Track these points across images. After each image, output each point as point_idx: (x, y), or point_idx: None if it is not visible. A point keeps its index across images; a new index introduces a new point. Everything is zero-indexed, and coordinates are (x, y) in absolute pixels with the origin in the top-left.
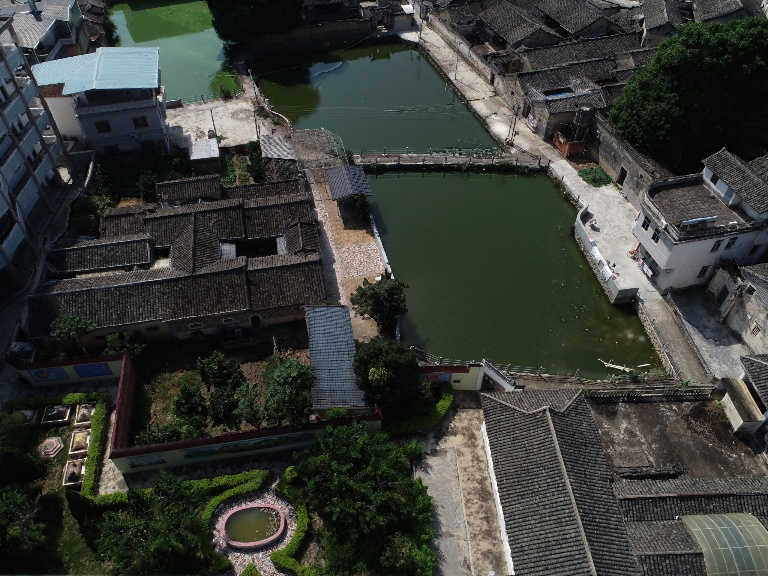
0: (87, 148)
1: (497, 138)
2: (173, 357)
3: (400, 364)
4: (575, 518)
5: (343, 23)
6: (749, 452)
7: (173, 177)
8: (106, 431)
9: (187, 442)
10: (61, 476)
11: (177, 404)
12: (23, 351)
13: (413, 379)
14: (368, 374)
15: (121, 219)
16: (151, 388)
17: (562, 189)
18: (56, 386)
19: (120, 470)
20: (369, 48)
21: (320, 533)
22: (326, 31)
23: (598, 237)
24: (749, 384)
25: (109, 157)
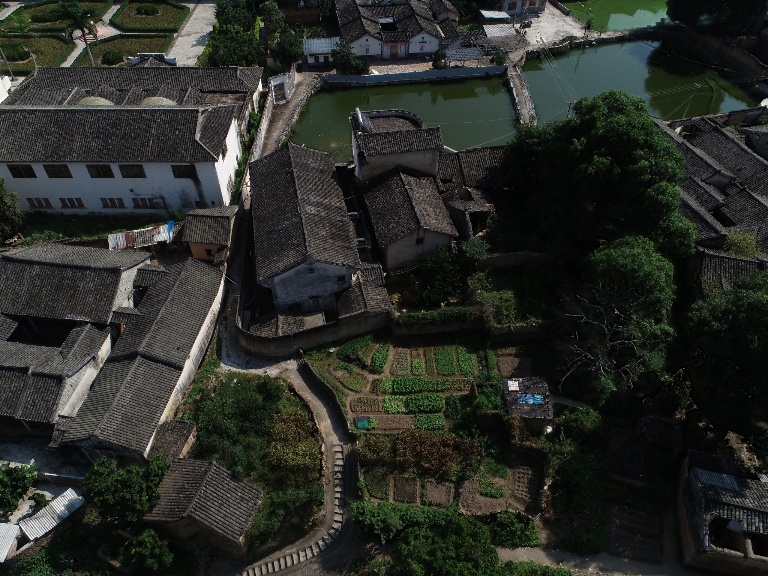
0: None
1: None
2: (330, 30)
3: (281, 42)
4: None
5: (747, 56)
6: None
7: (458, 6)
8: None
9: None
10: None
11: None
12: None
13: None
14: None
15: None
16: None
17: None
18: None
19: None
20: (734, 87)
21: None
22: (732, 54)
23: None
24: None
25: None
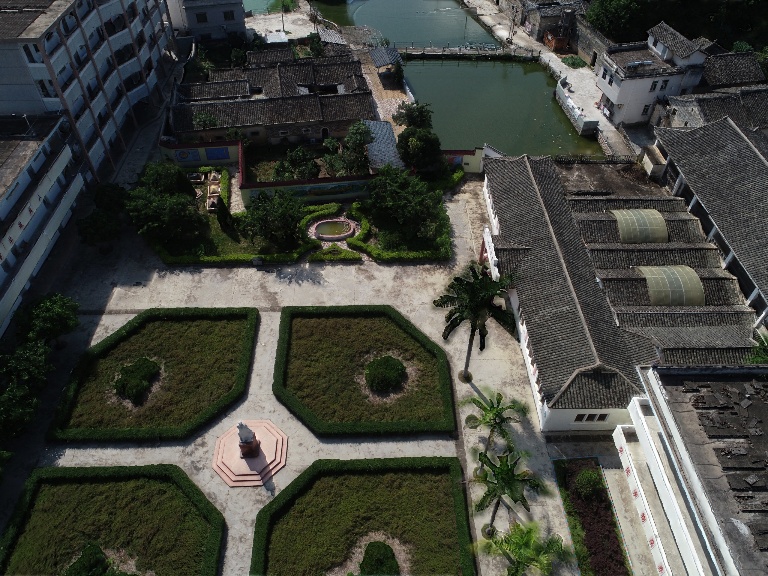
0: (188, 35)
1: (500, 39)
2: (268, 154)
3: (429, 138)
4: (539, 201)
5: None
6: (657, 186)
7: None
8: (229, 188)
9: (289, 181)
10: (204, 207)
11: (277, 171)
12: (170, 140)
13: (437, 152)
14: (407, 146)
15: (224, 72)
16: (255, 169)
17: (548, 70)
18: (191, 166)
19: (243, 203)
20: None
21: (377, 233)
22: None
23: (573, 96)
24: (659, 146)
25: (204, 43)
